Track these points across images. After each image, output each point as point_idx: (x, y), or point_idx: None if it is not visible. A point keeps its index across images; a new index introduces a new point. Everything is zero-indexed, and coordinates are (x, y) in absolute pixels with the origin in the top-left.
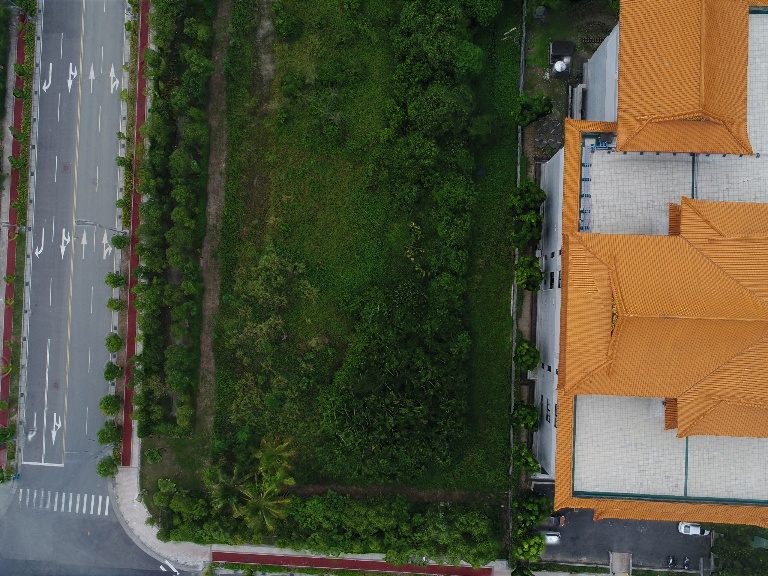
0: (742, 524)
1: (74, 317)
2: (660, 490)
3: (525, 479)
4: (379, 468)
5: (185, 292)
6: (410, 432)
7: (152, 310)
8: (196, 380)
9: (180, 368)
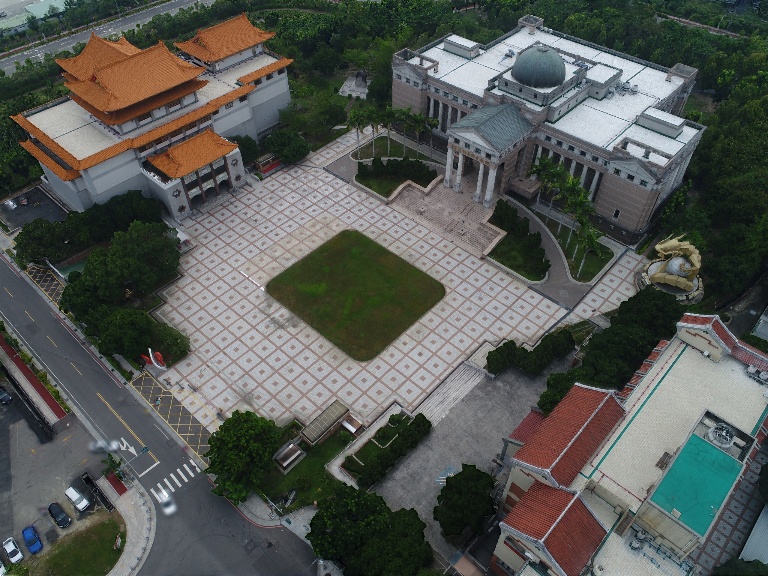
0: (73, 222)
1: (4, 70)
2: (48, 133)
3: (38, 183)
4: (3, 152)
5: (39, 70)
6: (21, 111)
7: (24, 72)
8: (2, 98)
9: (2, 82)
